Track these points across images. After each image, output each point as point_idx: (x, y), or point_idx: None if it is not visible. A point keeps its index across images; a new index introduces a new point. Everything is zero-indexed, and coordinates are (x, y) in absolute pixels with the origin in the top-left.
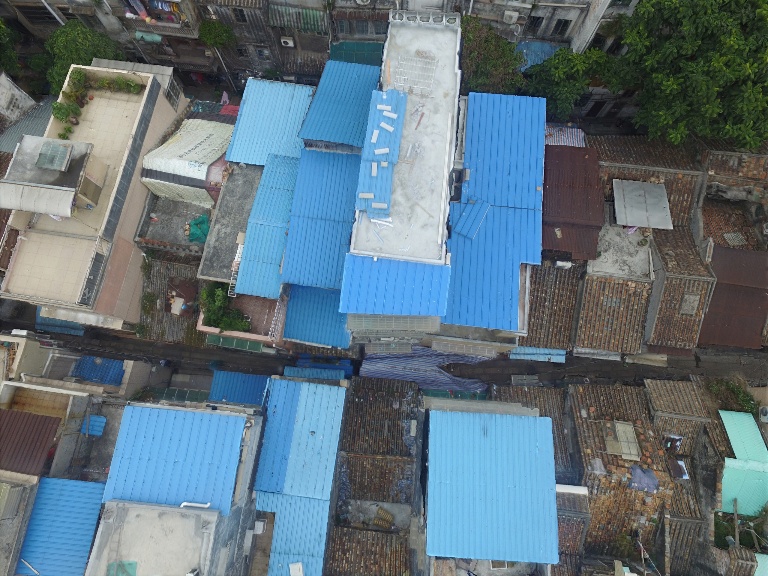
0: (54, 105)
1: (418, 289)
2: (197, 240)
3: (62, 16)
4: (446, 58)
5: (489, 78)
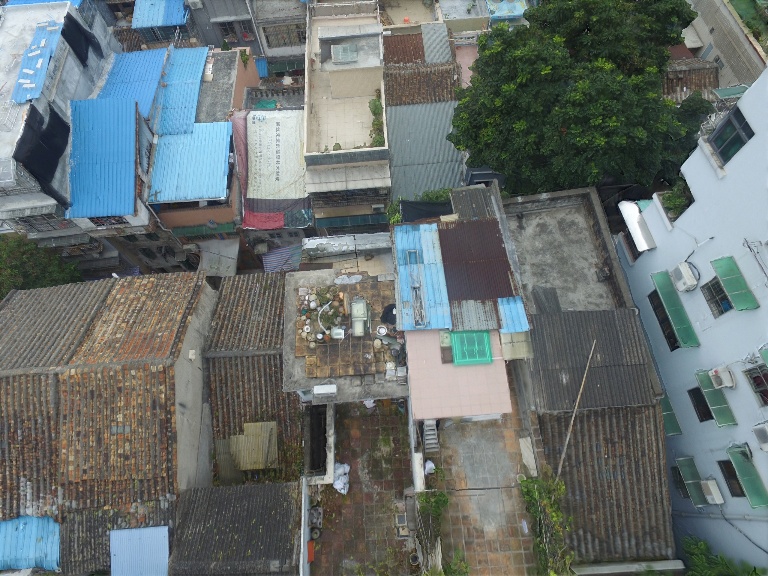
0: (377, 102)
1: (28, 1)
2: (269, 102)
3: None
4: None
5: None
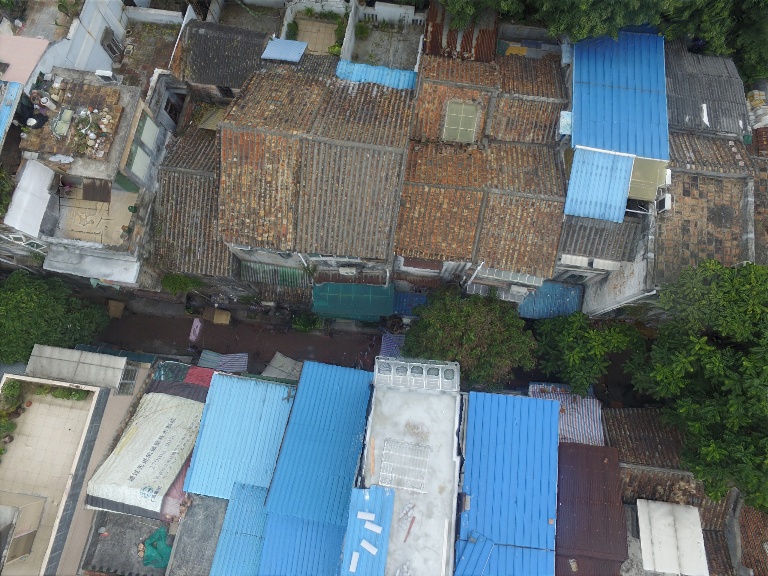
0: None
1: None
2: (152, 563)
3: (7, 258)
4: (442, 434)
5: (493, 367)
